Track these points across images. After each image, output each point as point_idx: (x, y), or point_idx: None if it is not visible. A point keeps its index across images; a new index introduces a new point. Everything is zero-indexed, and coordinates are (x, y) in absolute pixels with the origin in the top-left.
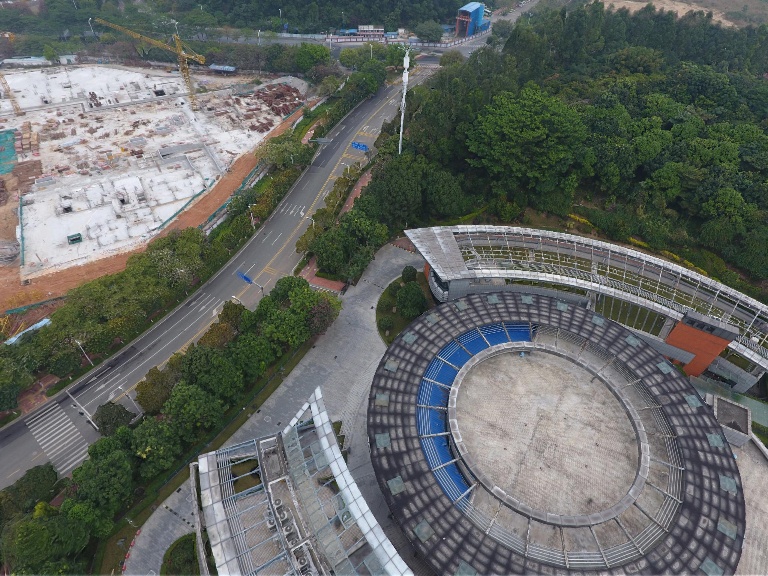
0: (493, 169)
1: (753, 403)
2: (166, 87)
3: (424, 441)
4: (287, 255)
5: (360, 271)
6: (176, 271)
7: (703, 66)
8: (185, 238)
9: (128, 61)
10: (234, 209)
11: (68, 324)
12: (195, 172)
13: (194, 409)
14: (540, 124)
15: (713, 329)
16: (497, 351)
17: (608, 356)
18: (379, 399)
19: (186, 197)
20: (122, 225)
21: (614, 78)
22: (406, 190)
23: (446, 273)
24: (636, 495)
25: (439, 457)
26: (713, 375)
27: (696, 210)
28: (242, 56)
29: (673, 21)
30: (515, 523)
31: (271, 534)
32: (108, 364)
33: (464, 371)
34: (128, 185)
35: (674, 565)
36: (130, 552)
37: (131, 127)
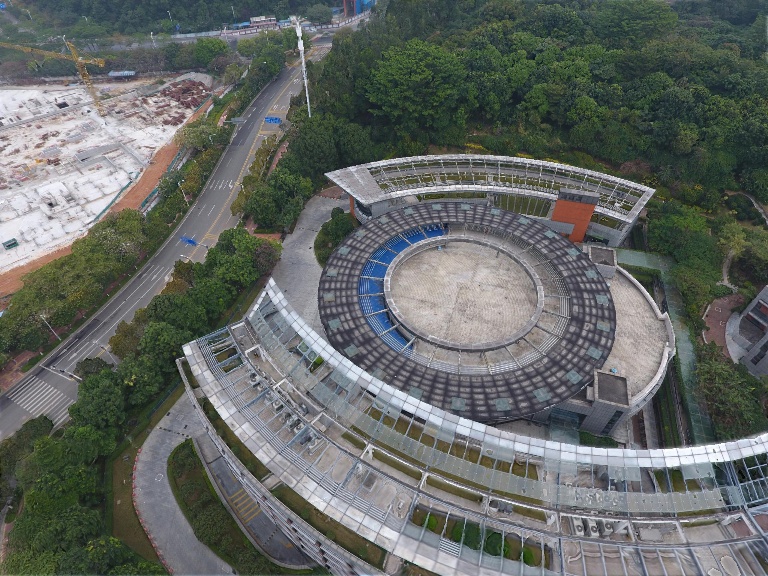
0: (393, 113)
1: (622, 252)
2: (68, 99)
3: (369, 318)
4: (224, 222)
5: (294, 221)
6: (122, 246)
7: (554, 5)
8: (124, 218)
9: (20, 80)
10: (165, 190)
11: (29, 303)
12: (118, 168)
13: (168, 338)
14: (425, 68)
15: (581, 198)
16: (418, 247)
17: (506, 235)
18: (326, 297)
19: (114, 191)
20: (56, 225)
21: (486, 27)
22: (320, 143)
23: (366, 199)
24: (536, 319)
25: (383, 327)
26: (592, 240)
27: (563, 120)
28: (140, 59)
29: None
30: (450, 360)
31: (255, 392)
32: (75, 337)
33: (393, 265)
34: (52, 190)
35: (568, 356)
36: (136, 466)
37: (41, 140)
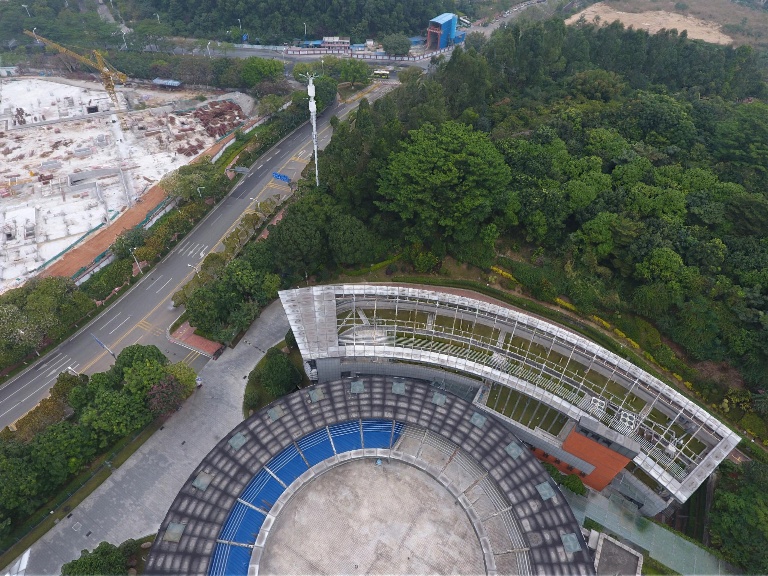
0: (401, 215)
1: (661, 533)
2: (101, 103)
3: None
4: (170, 306)
5: None
6: (17, 332)
7: (660, 96)
8: (40, 290)
9: (70, 74)
10: (117, 251)
11: None
12: (99, 202)
13: None
14: (453, 166)
15: (609, 443)
16: (341, 461)
17: (479, 471)
18: (171, 531)
19: (81, 232)
20: None
21: (568, 105)
22: (298, 238)
23: (310, 350)
24: None
25: None
26: None
27: (629, 271)
28: (187, 70)
29: (642, 40)
30: None
31: None
32: None
33: (290, 491)
34: (20, 217)
35: None
36: None
37: (50, 148)
